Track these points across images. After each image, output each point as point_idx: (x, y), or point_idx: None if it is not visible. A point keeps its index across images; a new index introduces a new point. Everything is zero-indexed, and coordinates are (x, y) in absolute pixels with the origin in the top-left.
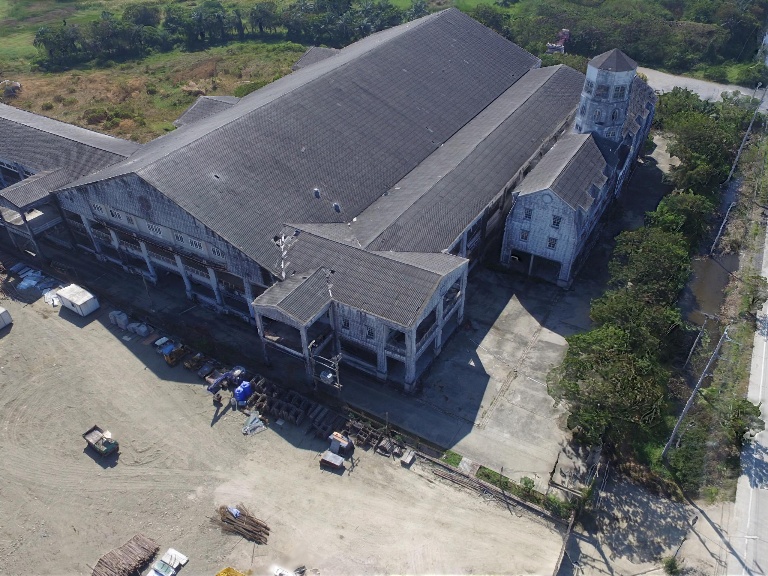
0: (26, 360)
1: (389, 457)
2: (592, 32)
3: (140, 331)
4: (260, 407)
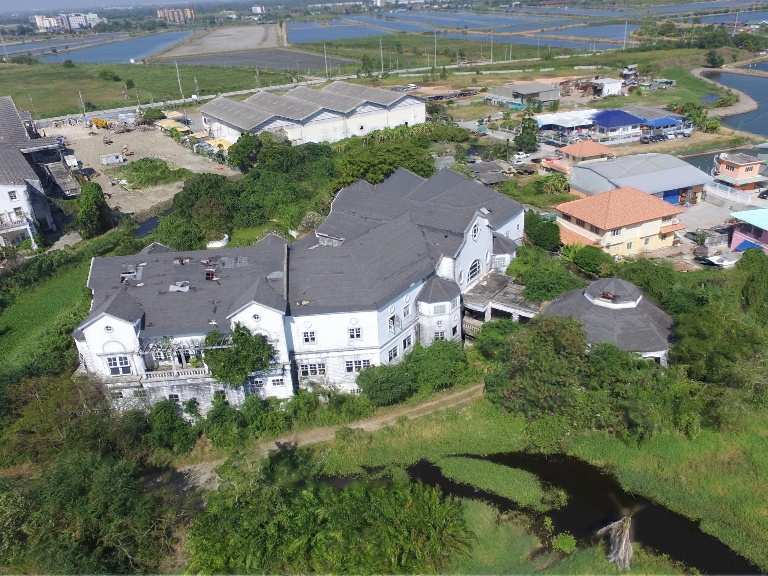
0: None
1: None
2: None
3: None
4: None
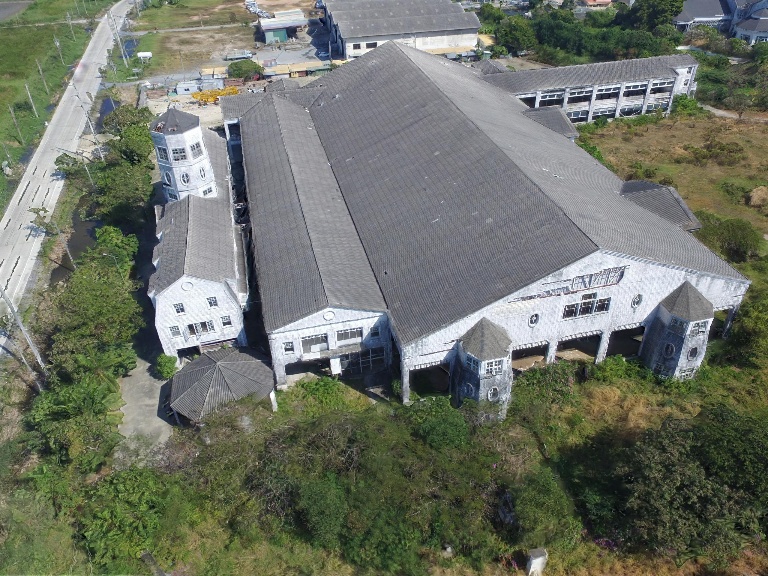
0: None
1: None
2: None
3: None
4: None
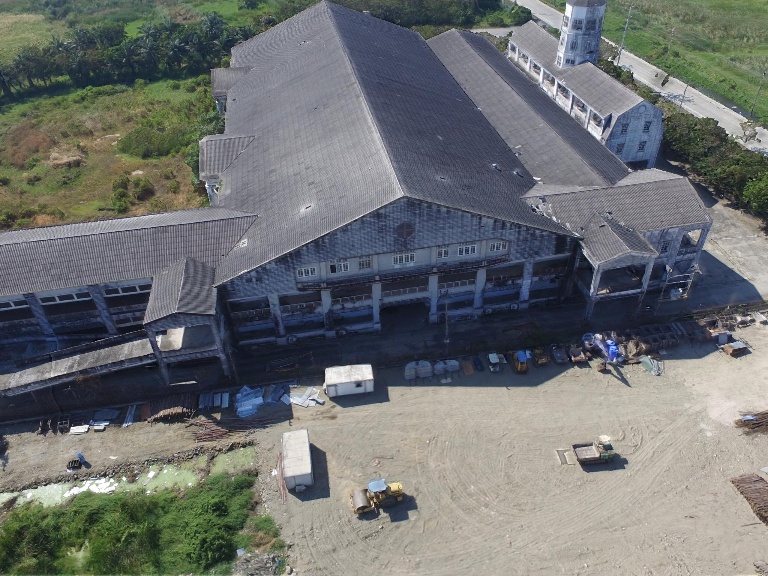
0: (392, 458)
1: (751, 325)
2: (390, 8)
3: (454, 366)
4: (640, 351)
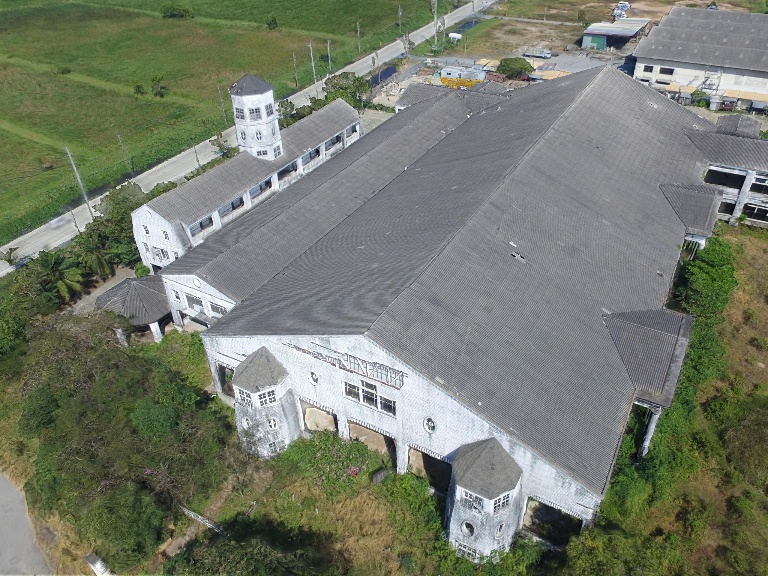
0: None
1: None
2: None
3: None
4: None
